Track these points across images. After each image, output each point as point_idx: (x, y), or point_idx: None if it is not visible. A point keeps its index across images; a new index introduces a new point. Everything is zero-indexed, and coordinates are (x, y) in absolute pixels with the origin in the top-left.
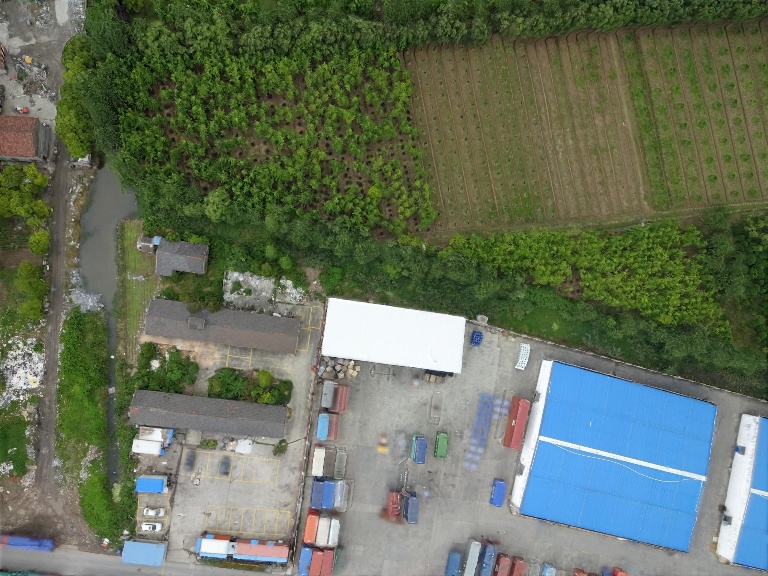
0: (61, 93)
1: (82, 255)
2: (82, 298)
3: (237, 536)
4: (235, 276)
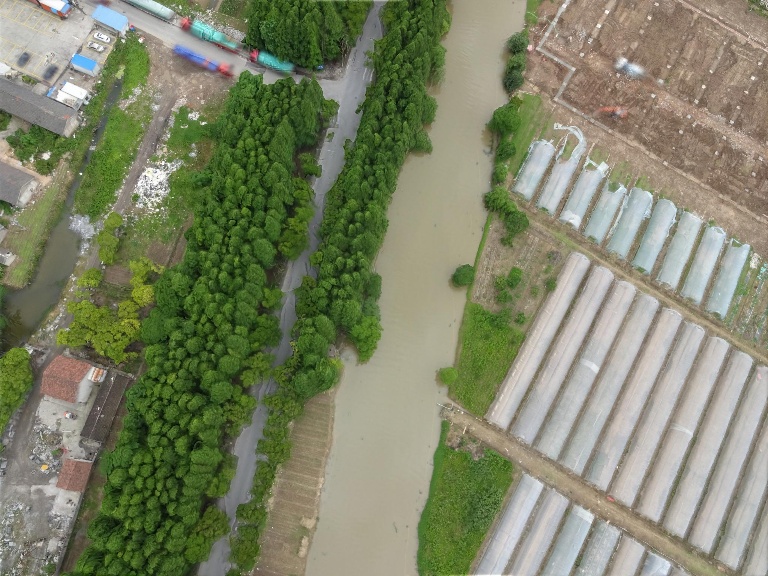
0: (4, 410)
1: (72, 267)
2: (85, 229)
3: (39, 8)
4: None
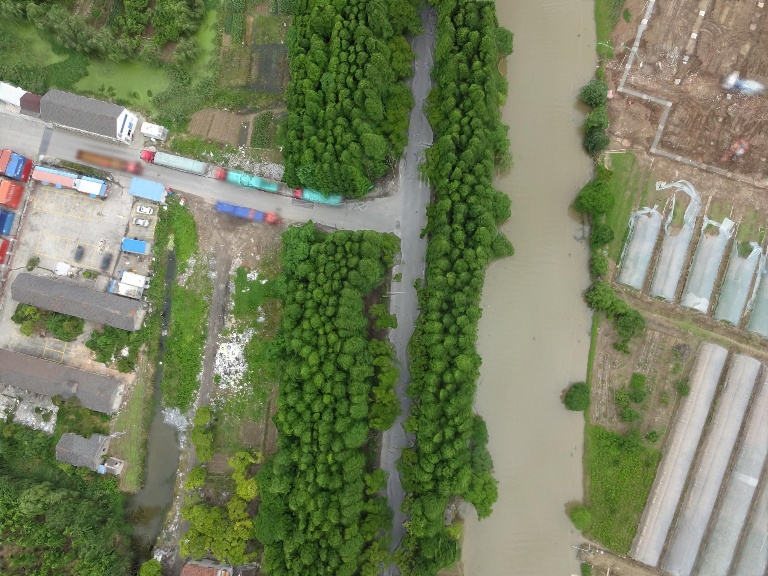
0: None
1: (177, 462)
2: (178, 421)
3: (79, 193)
4: (48, 427)
